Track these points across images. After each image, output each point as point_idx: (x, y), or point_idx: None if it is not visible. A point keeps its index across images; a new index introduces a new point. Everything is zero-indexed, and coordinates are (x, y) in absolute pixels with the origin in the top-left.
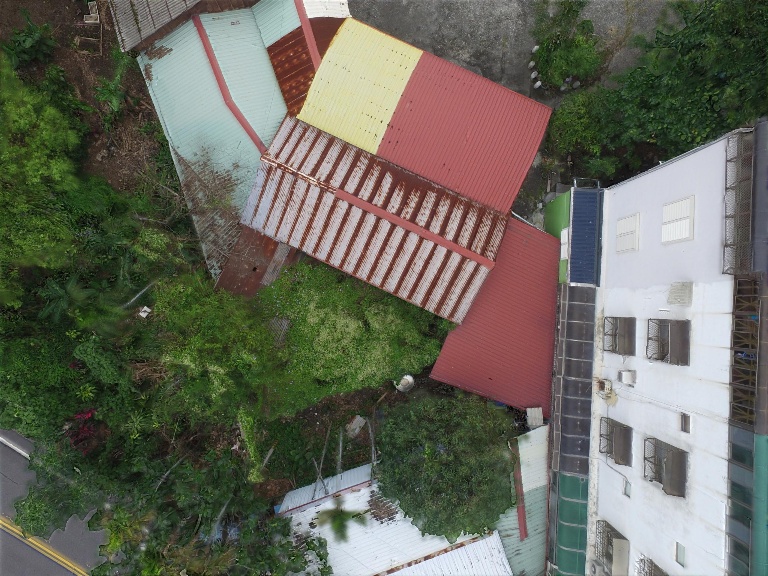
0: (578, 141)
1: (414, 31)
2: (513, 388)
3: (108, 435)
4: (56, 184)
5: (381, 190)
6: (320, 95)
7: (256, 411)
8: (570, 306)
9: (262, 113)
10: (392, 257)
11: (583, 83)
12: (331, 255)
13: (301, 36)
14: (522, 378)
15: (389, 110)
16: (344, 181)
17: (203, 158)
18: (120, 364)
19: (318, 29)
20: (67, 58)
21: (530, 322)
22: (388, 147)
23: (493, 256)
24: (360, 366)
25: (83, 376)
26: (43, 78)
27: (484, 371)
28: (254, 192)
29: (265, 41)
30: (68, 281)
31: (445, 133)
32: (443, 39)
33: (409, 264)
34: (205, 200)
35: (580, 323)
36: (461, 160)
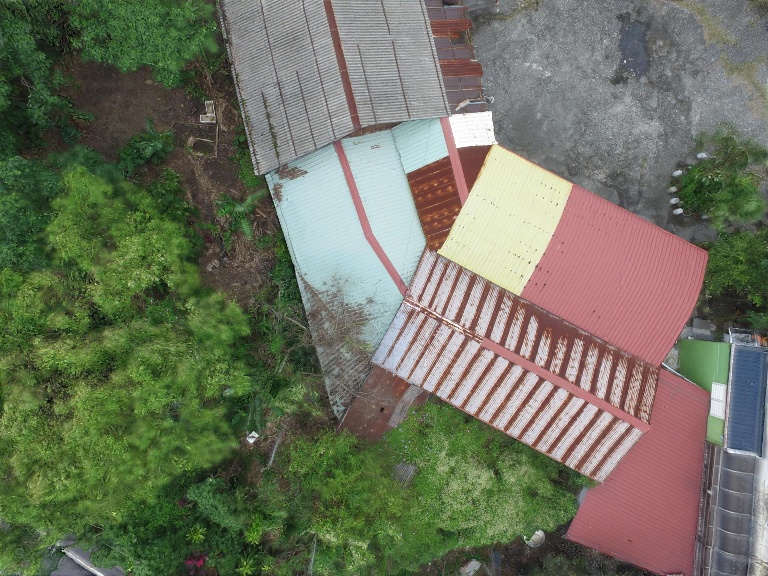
0: (729, 284)
1: (548, 147)
2: (653, 551)
3: (211, 572)
4: (188, 325)
5: (527, 338)
6: (465, 230)
7: (384, 571)
8: (725, 472)
9: (401, 246)
10: (536, 410)
11: (726, 211)
12: (468, 402)
13: (448, 167)
14: (663, 540)
15: (539, 251)
16: (489, 328)
17: (333, 288)
18: (235, 506)
19: (466, 160)
20: (180, 159)
21: (674, 480)
22: (534, 289)
23: (647, 417)
24: (490, 519)
25: (190, 512)
26: (154, 180)
27: (623, 532)
28: (391, 333)
29: (405, 166)
30: (182, 412)
31: (597, 278)
32: (578, 157)
33: (554, 419)
34: (331, 331)
35: (737, 494)
36: (613, 308)
